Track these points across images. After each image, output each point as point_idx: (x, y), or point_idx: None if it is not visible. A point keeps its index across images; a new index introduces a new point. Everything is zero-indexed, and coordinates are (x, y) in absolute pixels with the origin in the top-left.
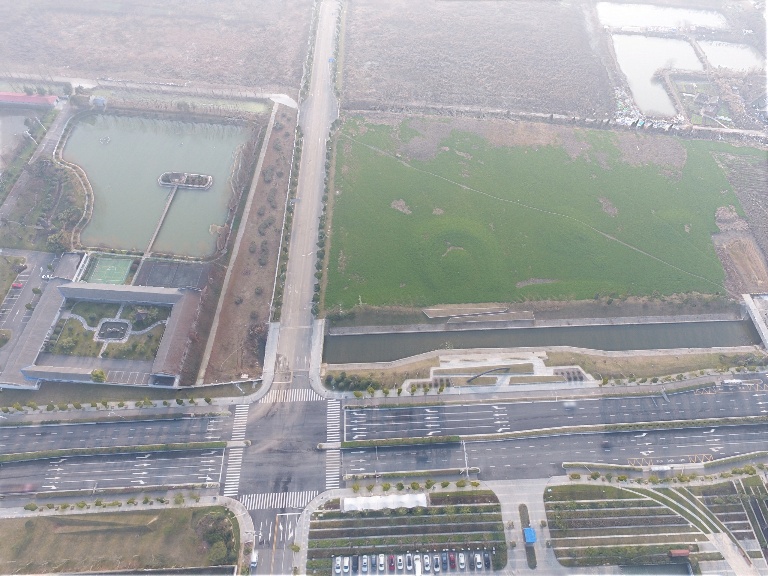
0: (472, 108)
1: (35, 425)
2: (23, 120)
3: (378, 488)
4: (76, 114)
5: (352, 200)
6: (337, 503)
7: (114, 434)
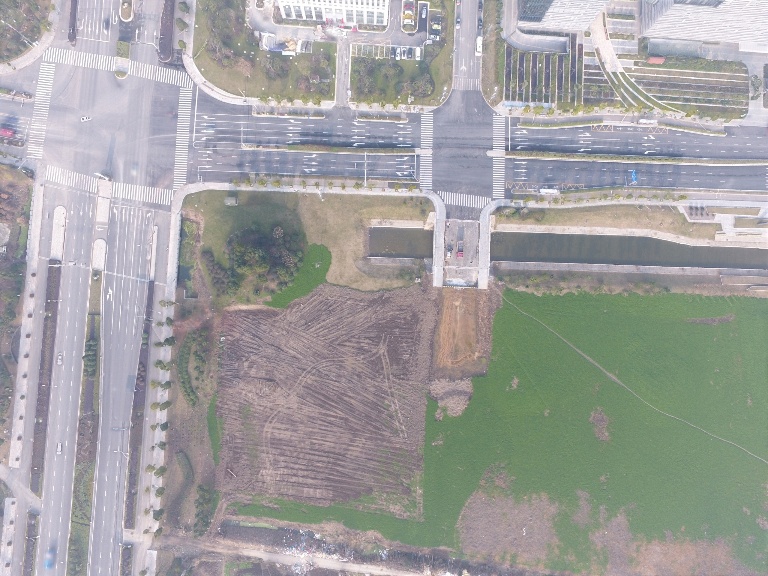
0: None
1: None
2: None
3: None
4: None
5: None
6: None
7: None
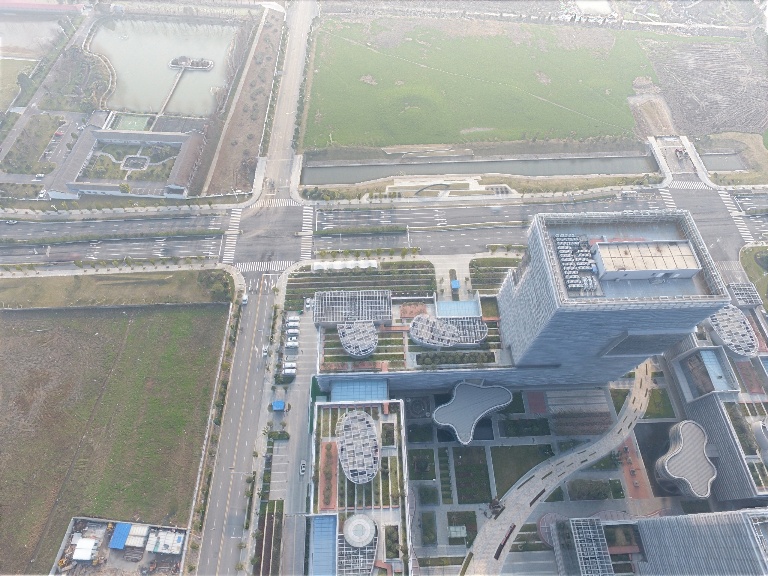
0: (434, 10)
1: (78, 221)
2: (56, 21)
3: (341, 259)
4: (99, 18)
5: (328, 76)
6: (309, 268)
7: (138, 226)
